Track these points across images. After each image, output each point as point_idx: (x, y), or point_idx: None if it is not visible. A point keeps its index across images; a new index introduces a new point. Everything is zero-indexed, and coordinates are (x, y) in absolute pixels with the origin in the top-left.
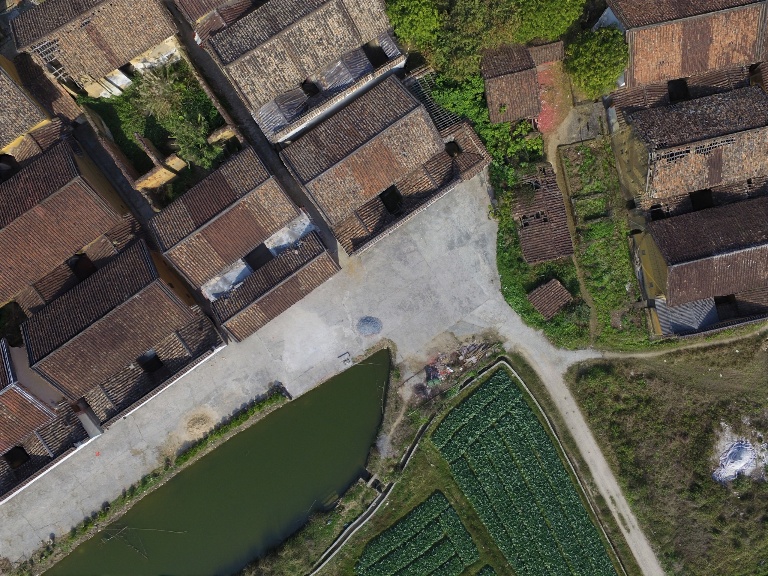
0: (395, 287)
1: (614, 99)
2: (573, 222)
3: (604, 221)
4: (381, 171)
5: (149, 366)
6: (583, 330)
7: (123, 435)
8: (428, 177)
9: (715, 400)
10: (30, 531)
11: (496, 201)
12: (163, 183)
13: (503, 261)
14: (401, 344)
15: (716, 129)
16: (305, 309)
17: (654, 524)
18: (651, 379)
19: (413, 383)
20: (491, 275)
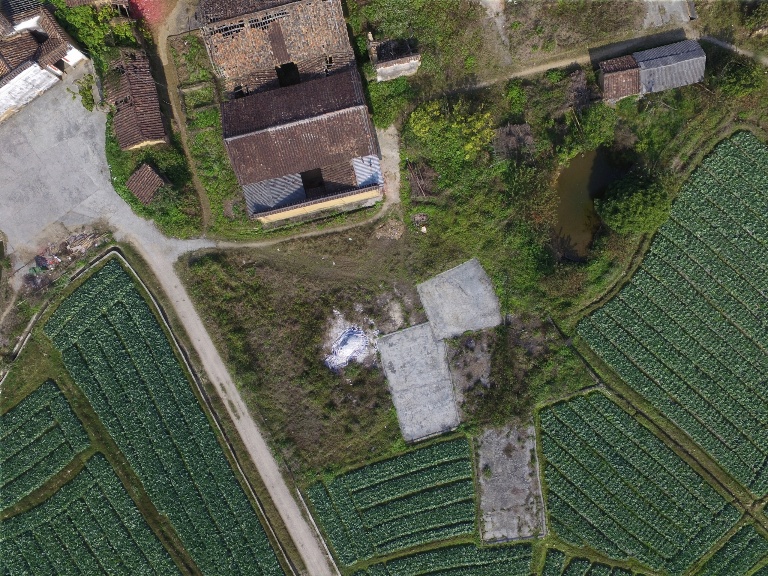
0: (5, 179)
1: None
2: None
3: (208, 109)
4: None
5: None
6: (192, 219)
7: None
8: (2, 60)
9: (327, 288)
10: None
11: (101, 91)
12: None
13: (111, 151)
14: (12, 235)
15: (270, 2)
16: None
17: (265, 411)
18: (262, 267)
19: (23, 273)
20: (100, 166)
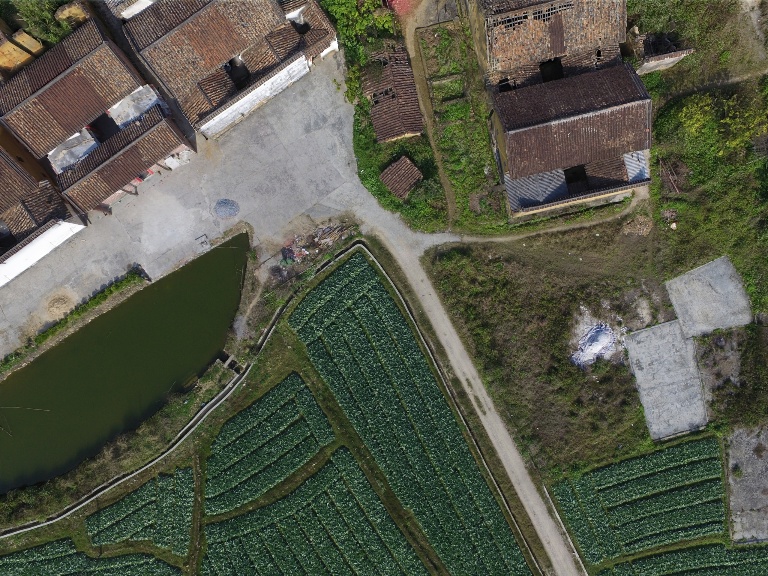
0: (252, 170)
1: None
2: (431, 105)
3: (459, 102)
4: (220, 42)
5: (4, 242)
6: (440, 213)
7: None
8: (271, 51)
9: (574, 284)
10: None
11: None
12: (18, 63)
13: (359, 144)
14: (258, 227)
15: None
16: (163, 192)
17: (511, 407)
18: (509, 262)
19: (269, 265)
20: (348, 158)
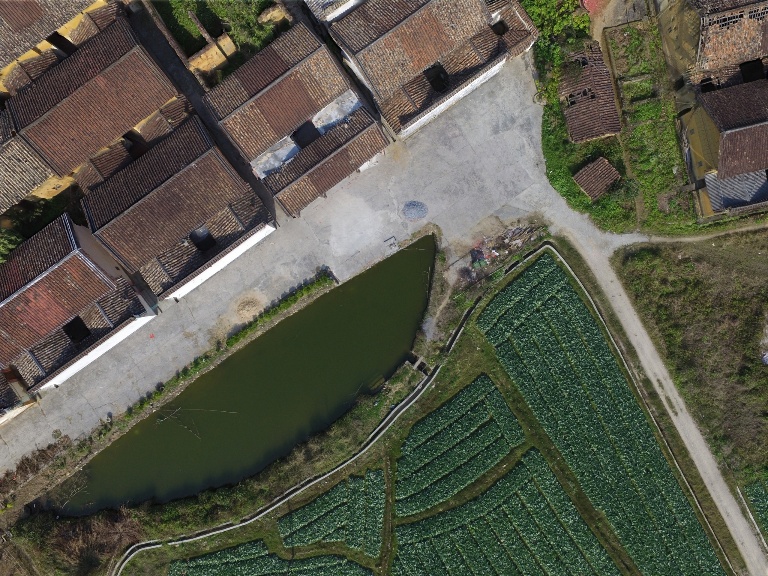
0: (440, 172)
1: None
2: (619, 105)
3: (651, 102)
4: (429, 43)
5: (202, 245)
6: (630, 213)
7: (176, 318)
8: (475, 52)
9: (765, 283)
10: (89, 410)
11: (541, 84)
12: (213, 67)
13: (548, 144)
14: (446, 228)
15: None
16: (351, 194)
17: (702, 407)
18: (699, 262)
19: (458, 267)
20: (536, 159)
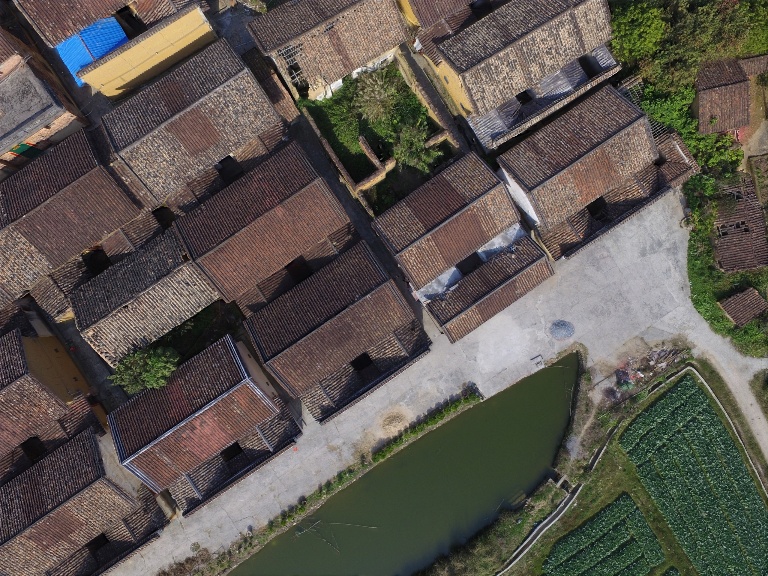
0: (587, 292)
1: None
2: None
3: None
4: (599, 179)
5: (357, 364)
6: None
7: (320, 431)
8: (638, 185)
9: None
10: (229, 523)
11: (689, 210)
12: (372, 185)
13: (694, 269)
14: (592, 348)
15: None
16: (500, 312)
17: None
18: None
19: (603, 386)
20: (681, 282)
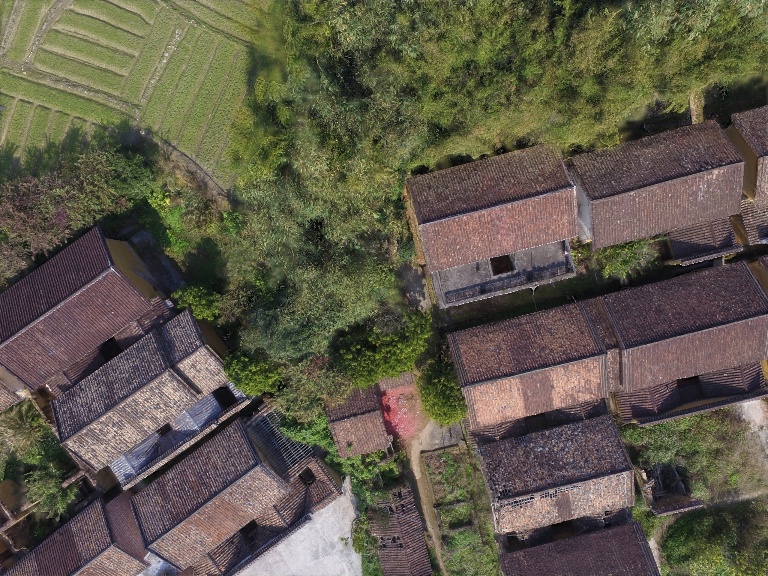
0: None
1: (466, 424)
2: (438, 527)
3: (467, 531)
4: (227, 520)
5: None
6: None
7: None
8: (278, 515)
9: None
10: None
11: (358, 512)
12: (27, 515)
13: (368, 570)
14: None
15: (561, 475)
16: None
17: None
18: None
19: None
20: None
